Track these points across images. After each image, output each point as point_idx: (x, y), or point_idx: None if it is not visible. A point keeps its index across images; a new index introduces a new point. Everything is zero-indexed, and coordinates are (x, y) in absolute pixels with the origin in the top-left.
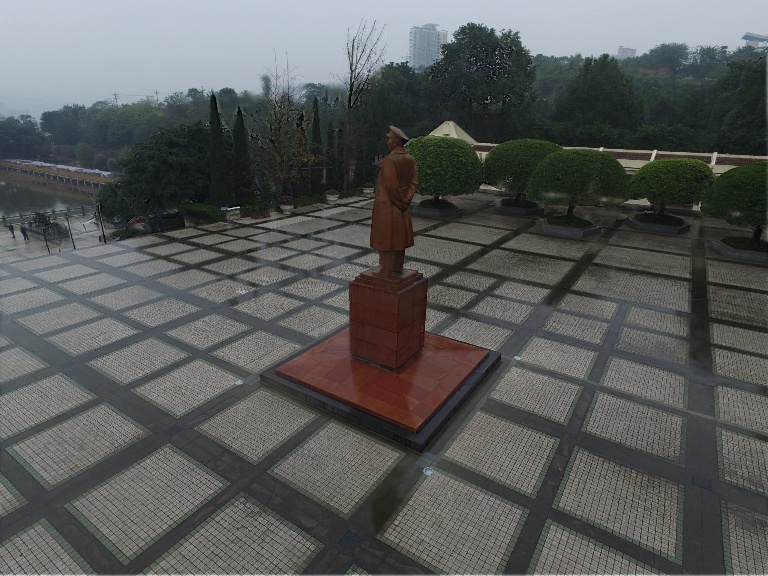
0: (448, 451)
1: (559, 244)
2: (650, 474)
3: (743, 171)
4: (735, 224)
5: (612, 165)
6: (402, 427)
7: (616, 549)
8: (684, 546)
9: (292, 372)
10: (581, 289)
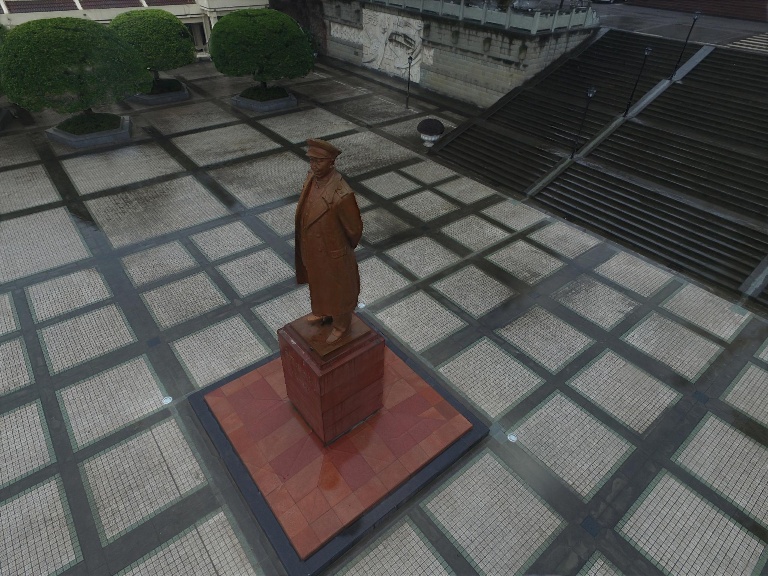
0: (489, 413)
1: (130, 158)
2: (526, 312)
3: (240, 25)
4: (259, 80)
5: (116, 38)
6: (462, 437)
7: (589, 362)
8: (584, 332)
9: (323, 533)
10: (254, 204)
